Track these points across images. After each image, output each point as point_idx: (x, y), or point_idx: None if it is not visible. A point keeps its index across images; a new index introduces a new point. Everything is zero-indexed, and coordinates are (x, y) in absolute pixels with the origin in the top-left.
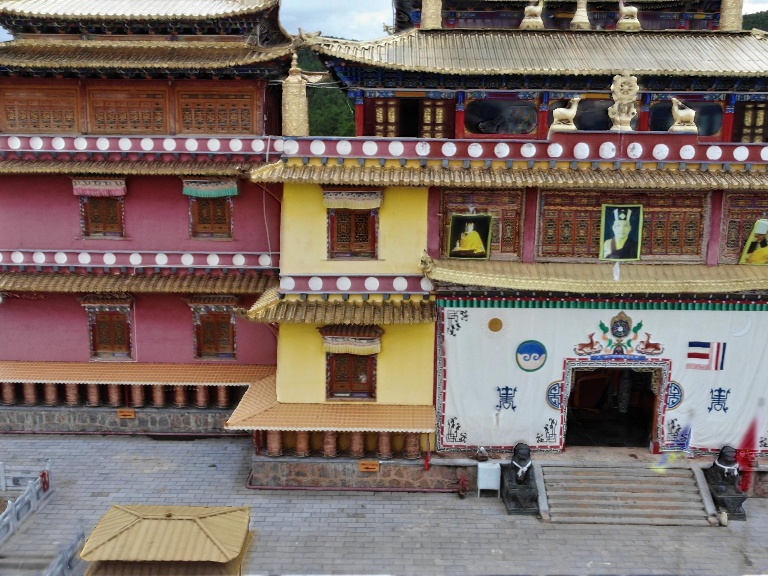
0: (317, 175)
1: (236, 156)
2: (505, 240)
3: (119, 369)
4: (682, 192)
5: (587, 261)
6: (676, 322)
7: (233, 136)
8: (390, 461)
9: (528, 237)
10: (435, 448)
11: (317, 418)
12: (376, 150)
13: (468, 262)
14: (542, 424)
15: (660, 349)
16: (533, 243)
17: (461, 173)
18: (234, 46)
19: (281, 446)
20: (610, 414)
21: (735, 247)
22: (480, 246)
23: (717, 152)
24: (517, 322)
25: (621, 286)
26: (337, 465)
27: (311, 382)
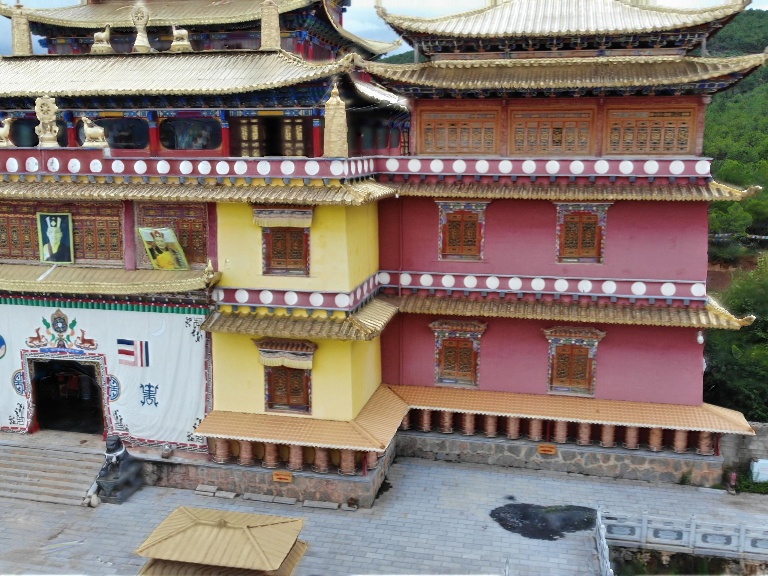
0: None
1: None
2: None
3: None
4: (102, 202)
5: (32, 263)
6: (103, 321)
7: None
8: None
9: None
10: None
11: None
12: None
13: None
14: (13, 408)
15: (94, 345)
16: None
17: None
18: None
19: None
20: None
21: None
22: None
23: (120, 166)
24: None
25: (41, 286)
26: None
27: None
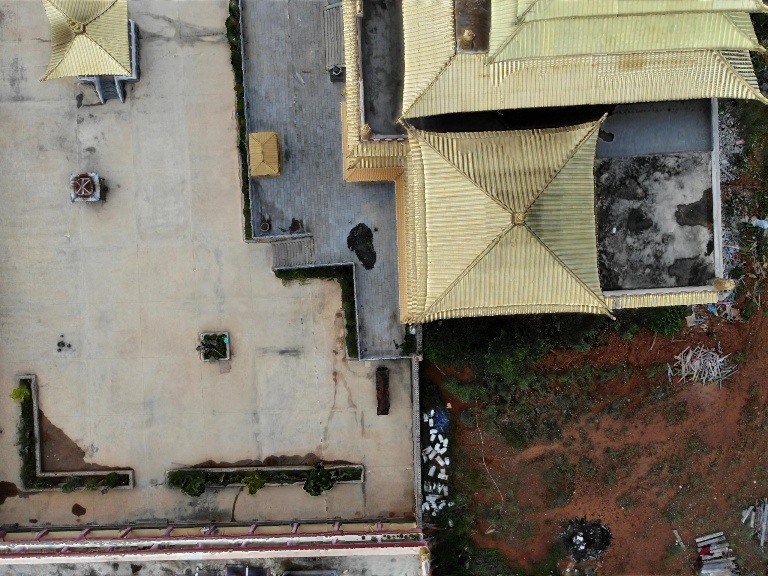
0: None
1: None
2: None
3: None
4: None
5: None
6: None
7: None
8: None
9: None
10: None
11: None
12: None
13: None
14: None
15: None
16: None
17: None
18: None
19: None
20: None
21: None
22: None
23: None
24: None
25: None
26: None
27: None
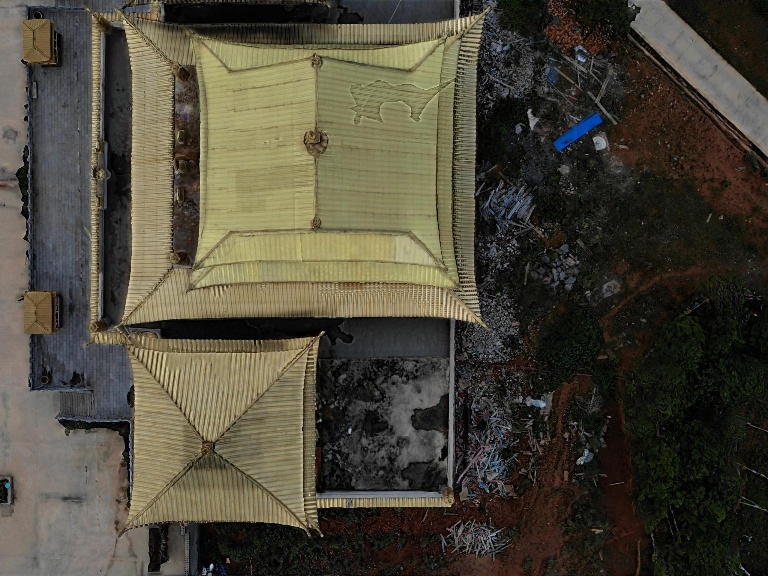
0: (94, 43)
1: None
2: None
3: None
4: None
5: None
6: None
7: None
8: None
9: None
10: None
11: None
12: None
13: None
14: None
15: None
16: None
17: (98, 106)
18: None
19: None
20: None
21: None
22: None
23: None
24: None
25: None
26: None
27: None
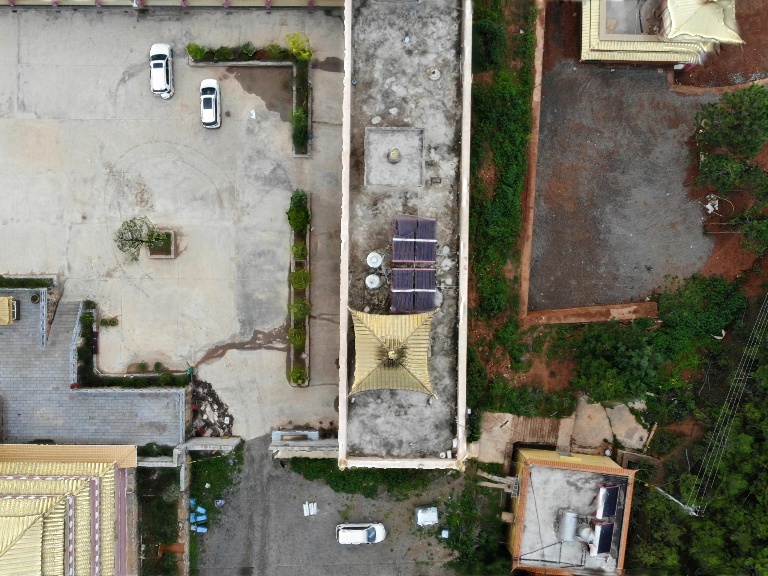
0: None
1: None
2: None
3: (56, 457)
4: None
5: None
6: None
7: None
8: None
9: None
10: None
11: None
12: None
13: None
14: None
15: None
16: None
17: None
18: None
19: None
20: None
21: None
22: None
23: None
24: None
25: None
26: None
27: None
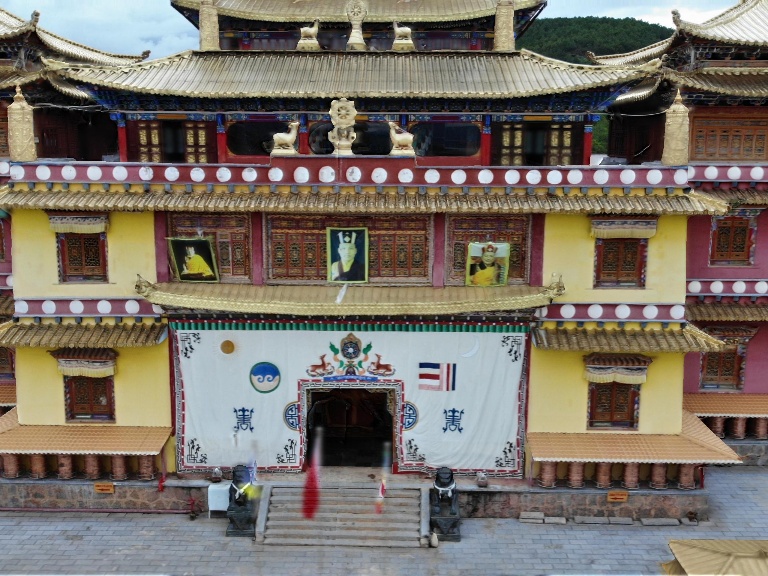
0: (34, 201)
1: (4, 178)
2: (236, 263)
3: None
4: (406, 215)
5: (316, 283)
6: (405, 343)
7: (1, 159)
8: (124, 482)
9: (255, 260)
10: (176, 469)
11: (48, 440)
12: (100, 175)
13: (198, 285)
14: (282, 445)
15: (391, 370)
16: (261, 266)
17: (179, 198)
18: (3, 70)
19: (18, 468)
20: (382, 432)
21: (462, 269)
22: (207, 269)
23: (435, 175)
24: (249, 344)
25: (342, 309)
26: (73, 487)
27: (50, 404)
